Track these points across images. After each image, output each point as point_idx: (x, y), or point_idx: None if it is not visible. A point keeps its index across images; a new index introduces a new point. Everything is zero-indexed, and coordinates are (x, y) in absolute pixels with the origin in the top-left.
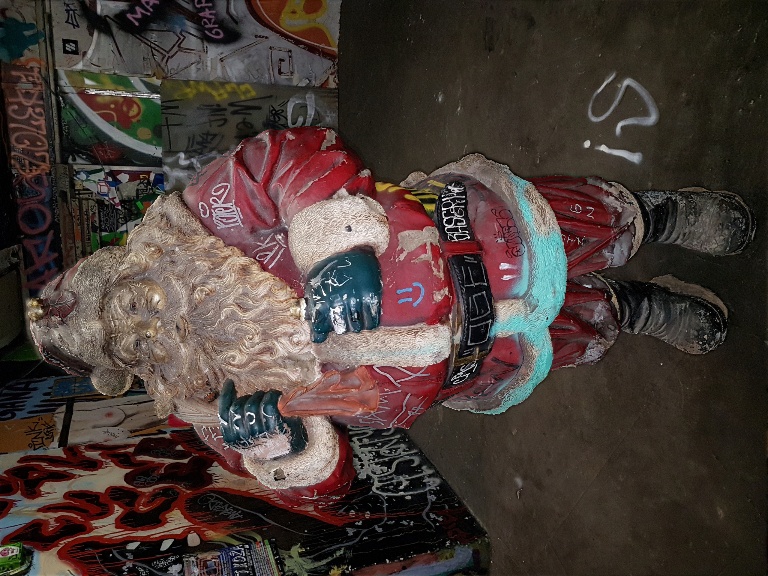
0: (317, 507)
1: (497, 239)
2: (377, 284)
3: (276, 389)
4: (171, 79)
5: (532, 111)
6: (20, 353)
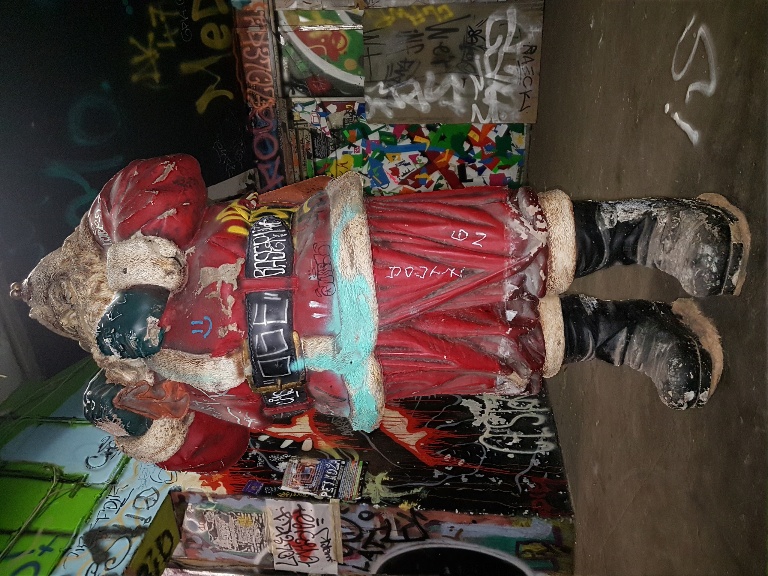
0: (419, 443)
1: (310, 276)
2: (141, 322)
3: (122, 384)
4: (372, 8)
5: (639, 55)
6: None
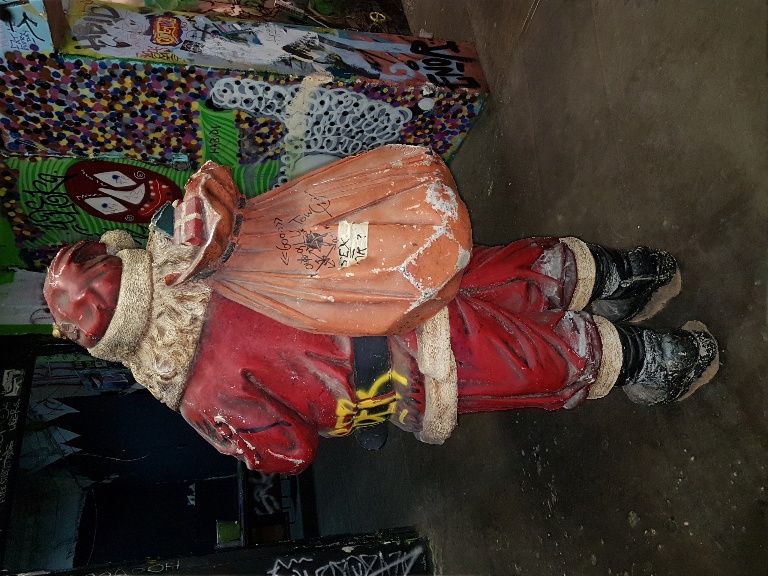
0: None
1: None
2: None
3: None
4: None
5: None
6: None
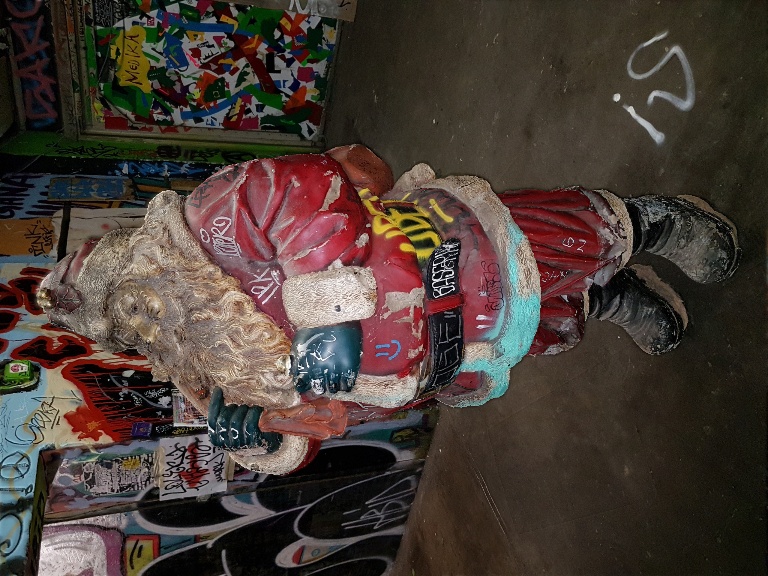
0: None
1: (480, 292)
2: (357, 359)
3: (259, 406)
4: None
5: (573, 31)
6: (14, 145)
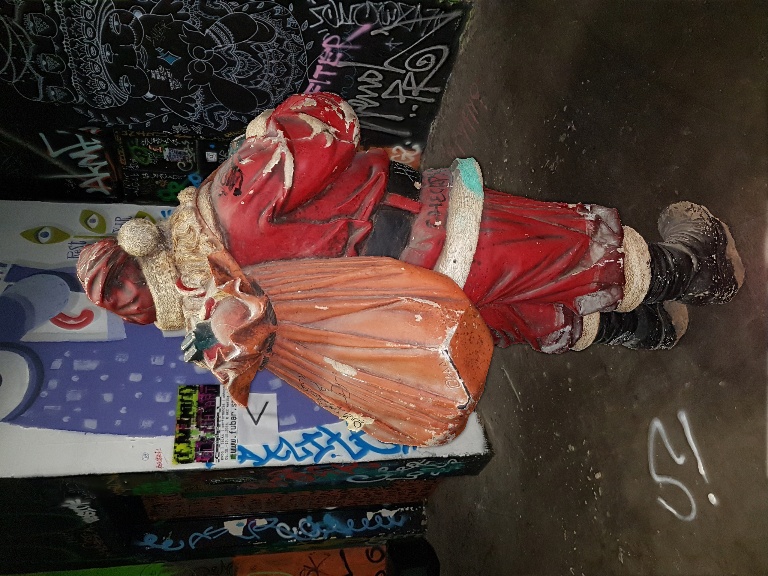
0: None
1: None
2: None
3: None
4: None
5: None
6: None
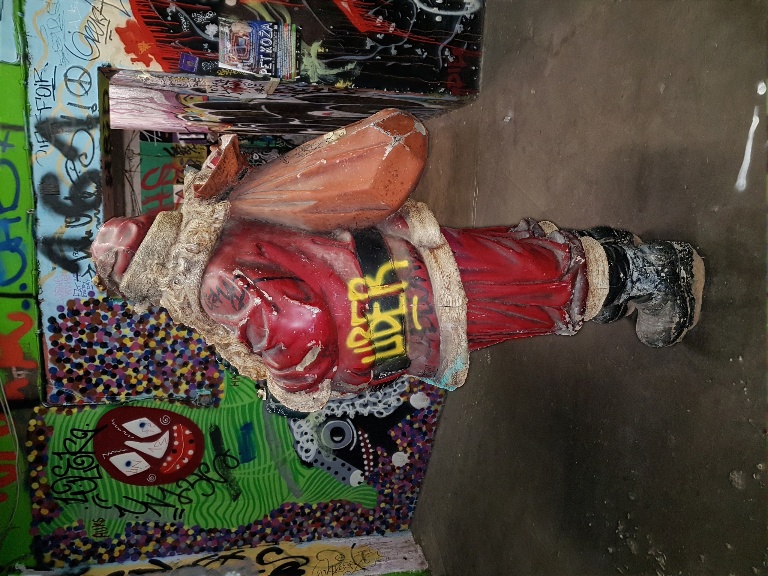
0: None
1: None
2: None
3: None
4: None
5: None
6: None
